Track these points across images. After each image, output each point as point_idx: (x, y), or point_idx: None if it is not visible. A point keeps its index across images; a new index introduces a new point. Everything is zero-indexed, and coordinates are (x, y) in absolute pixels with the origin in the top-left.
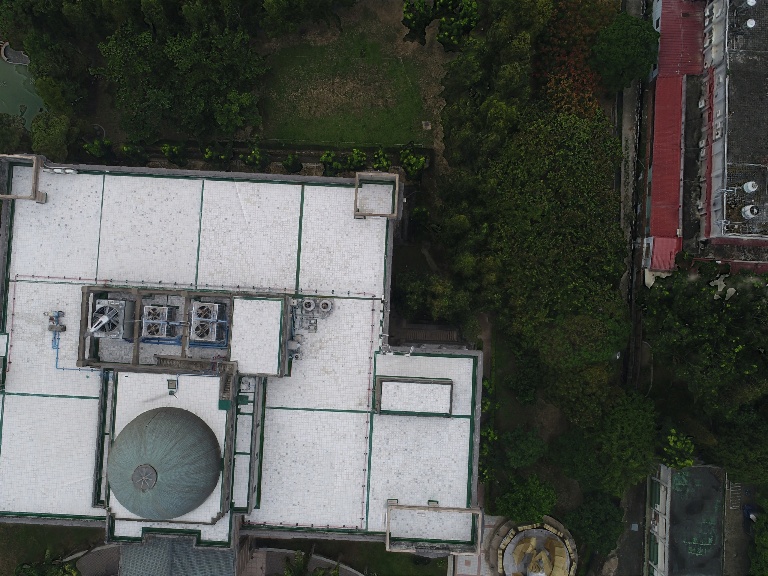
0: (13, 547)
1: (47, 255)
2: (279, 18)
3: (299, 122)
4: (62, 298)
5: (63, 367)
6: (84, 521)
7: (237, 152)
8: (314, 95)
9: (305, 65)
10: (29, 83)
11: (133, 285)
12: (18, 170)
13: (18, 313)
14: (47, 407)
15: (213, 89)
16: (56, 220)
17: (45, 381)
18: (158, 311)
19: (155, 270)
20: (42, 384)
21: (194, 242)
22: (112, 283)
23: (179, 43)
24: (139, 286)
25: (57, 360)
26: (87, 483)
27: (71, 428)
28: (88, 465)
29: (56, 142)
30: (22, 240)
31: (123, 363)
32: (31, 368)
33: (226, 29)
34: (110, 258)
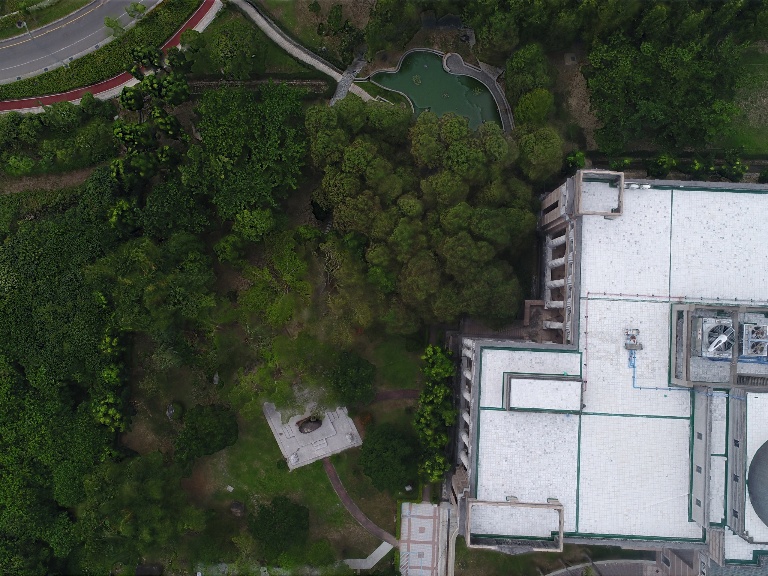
0: (483, 565)
1: (618, 272)
2: (766, 26)
3: (749, 131)
4: (635, 316)
5: (640, 386)
6: (675, 543)
7: (684, 162)
8: (764, 103)
9: (754, 73)
10: (471, 94)
11: (708, 302)
12: (584, 186)
13: (591, 331)
14: (625, 427)
15: (695, 99)
16: (625, 236)
17: (622, 400)
18: (761, 329)
19: (730, 287)
20: (619, 403)
21: (767, 258)
22: (686, 300)
23: (673, 53)
24: (714, 303)
25: (634, 379)
26: (669, 504)
27: (651, 448)
28: (670, 486)
29: (555, 155)
30: (591, 257)
31: (703, 382)
32: (607, 387)
33: (727, 38)
34: (683, 275)
